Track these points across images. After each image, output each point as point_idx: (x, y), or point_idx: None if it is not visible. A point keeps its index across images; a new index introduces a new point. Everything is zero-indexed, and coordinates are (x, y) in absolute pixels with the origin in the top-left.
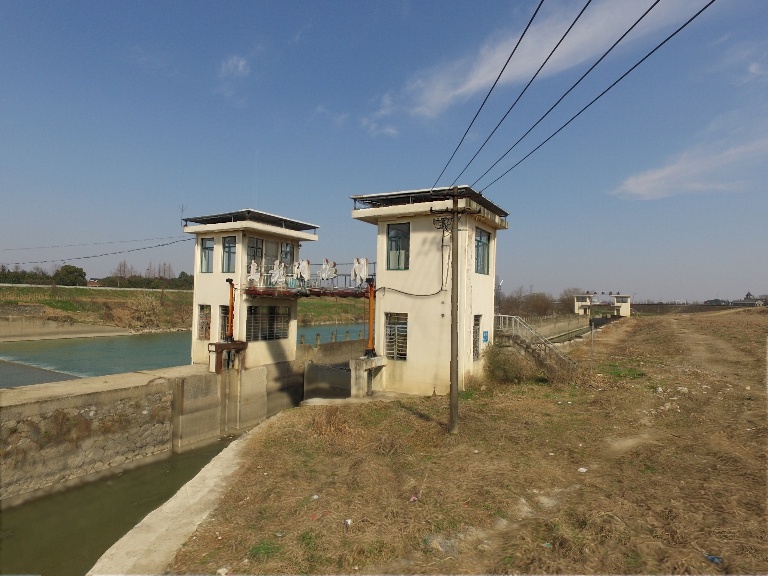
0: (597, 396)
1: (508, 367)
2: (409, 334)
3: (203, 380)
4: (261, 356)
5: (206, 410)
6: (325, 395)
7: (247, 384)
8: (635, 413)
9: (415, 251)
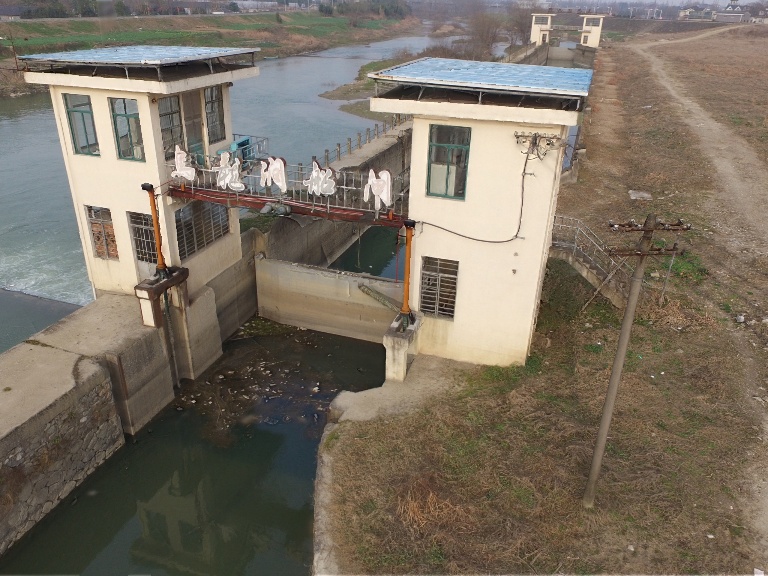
0: (687, 352)
1: (571, 302)
2: (460, 289)
3: (143, 344)
4: (202, 273)
5: (154, 378)
6: (293, 303)
7: (195, 322)
8: (750, 404)
9: (477, 175)
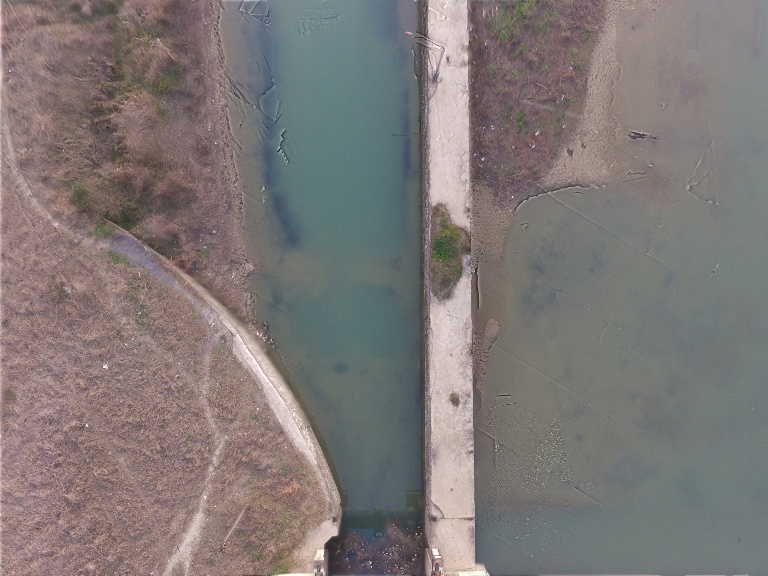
0: None
1: None
2: None
3: None
4: None
5: None
6: None
7: None
8: None
9: None
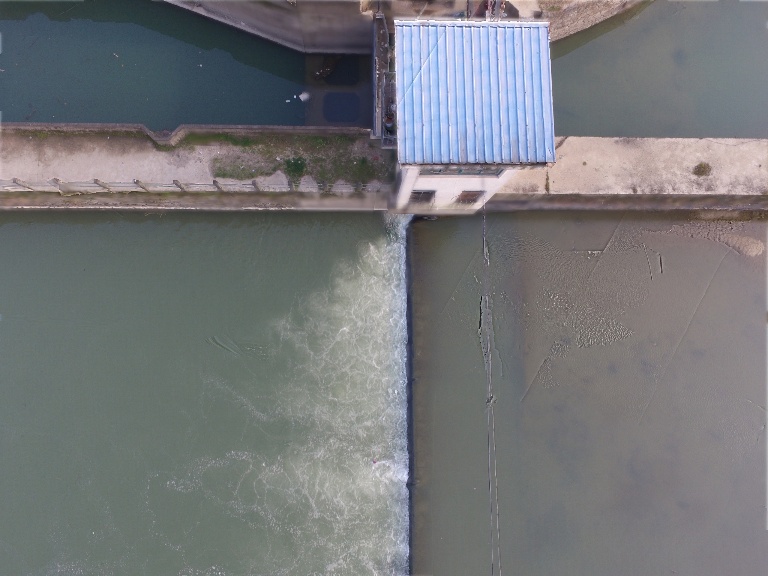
0: None
1: None
2: None
3: None
4: None
5: None
6: None
7: None
8: None
9: None
